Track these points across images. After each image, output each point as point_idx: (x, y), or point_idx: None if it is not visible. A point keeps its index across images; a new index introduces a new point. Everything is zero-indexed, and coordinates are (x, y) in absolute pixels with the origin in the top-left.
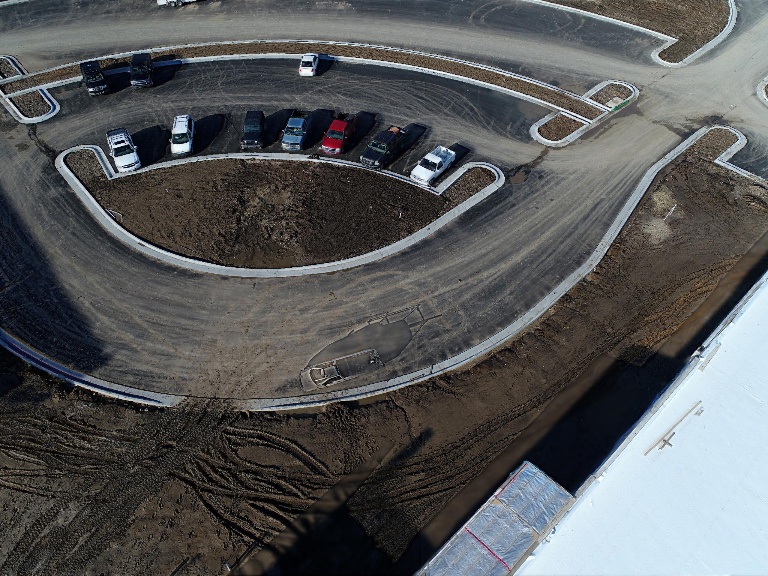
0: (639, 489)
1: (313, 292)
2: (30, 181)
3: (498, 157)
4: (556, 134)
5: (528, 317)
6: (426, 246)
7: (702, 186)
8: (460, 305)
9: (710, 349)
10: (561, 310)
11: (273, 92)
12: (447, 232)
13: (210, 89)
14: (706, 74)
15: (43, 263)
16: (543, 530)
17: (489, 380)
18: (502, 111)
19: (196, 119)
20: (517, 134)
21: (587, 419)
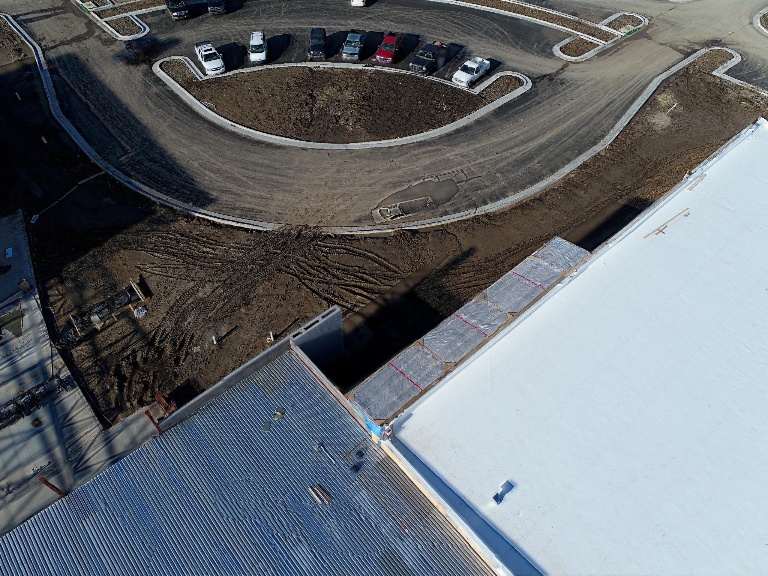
0: (639, 256)
1: (377, 159)
2: (134, 81)
3: (526, 68)
4: (575, 52)
5: (552, 178)
6: (467, 130)
7: (700, 90)
8: (497, 170)
9: (697, 173)
10: (579, 173)
11: (330, 18)
12: (484, 121)
13: (275, 16)
14: (708, 8)
15: (156, 137)
16: (568, 270)
17: (522, 217)
18: (528, 35)
19: (266, 38)
20: (542, 52)
21: (600, 242)
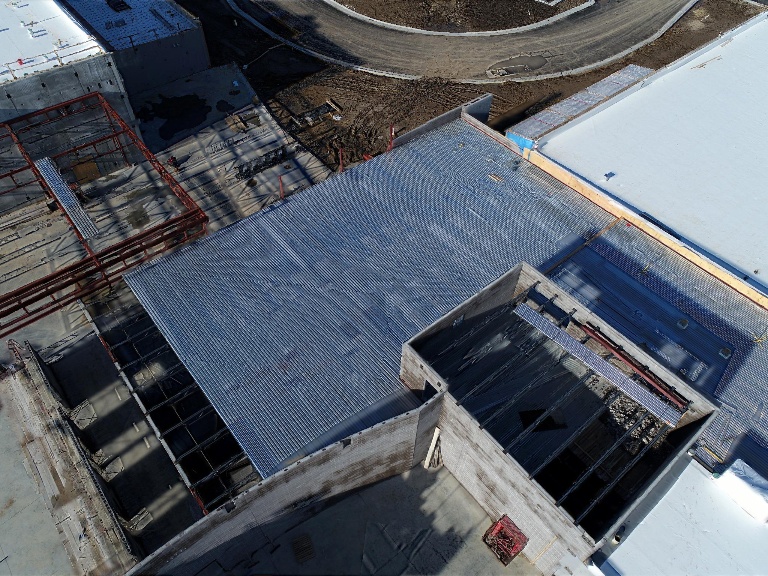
0: (687, 78)
1: (483, 43)
2: None
3: None
4: None
5: (616, 57)
6: (548, 28)
7: (727, 8)
8: (574, 51)
9: (727, 34)
10: (636, 54)
11: None
12: (561, 22)
13: None
14: None
15: (315, 25)
16: (641, 77)
17: (596, 77)
18: None
19: None
20: None
21: None
